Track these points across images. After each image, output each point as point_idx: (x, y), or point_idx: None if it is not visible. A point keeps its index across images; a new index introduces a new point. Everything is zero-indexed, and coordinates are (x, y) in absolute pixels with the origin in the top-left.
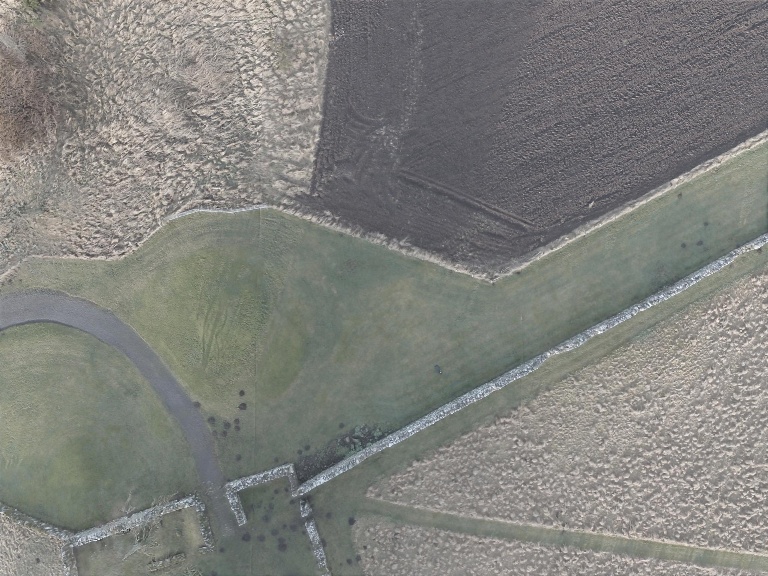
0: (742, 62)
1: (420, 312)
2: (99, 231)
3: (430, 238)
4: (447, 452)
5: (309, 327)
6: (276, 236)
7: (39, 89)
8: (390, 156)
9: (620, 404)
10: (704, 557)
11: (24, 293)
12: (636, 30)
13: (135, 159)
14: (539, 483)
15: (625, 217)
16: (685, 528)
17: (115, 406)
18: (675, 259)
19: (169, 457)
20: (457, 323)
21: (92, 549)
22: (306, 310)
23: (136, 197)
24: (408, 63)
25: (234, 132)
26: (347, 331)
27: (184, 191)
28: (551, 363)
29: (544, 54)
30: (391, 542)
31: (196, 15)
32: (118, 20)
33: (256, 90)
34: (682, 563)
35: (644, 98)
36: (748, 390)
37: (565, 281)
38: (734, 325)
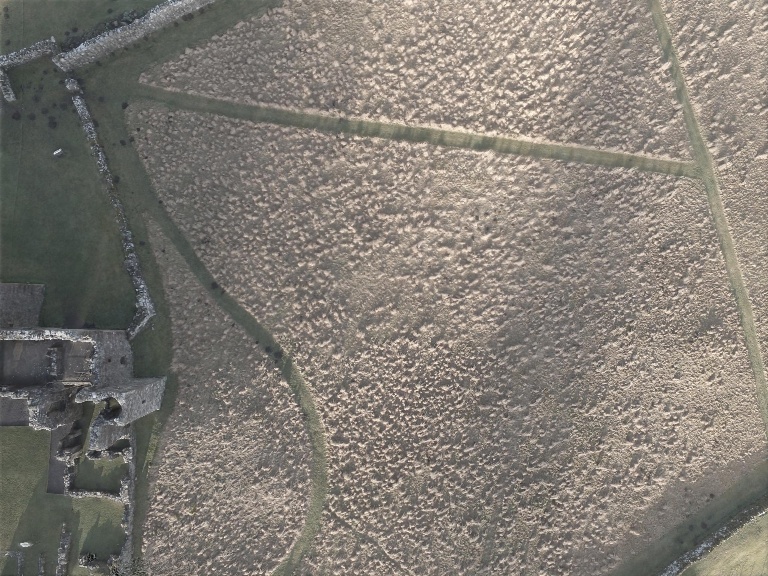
0: None
1: None
2: None
3: None
4: (220, 41)
5: None
6: None
7: None
8: None
9: None
10: (483, 144)
11: None
12: None
13: None
14: (313, 71)
15: None
16: (462, 115)
17: None
18: None
19: None
20: None
21: None
22: None
23: None
24: None
25: None
26: None
27: None
28: None
29: None
30: (165, 125)
31: None
32: None
33: None
34: (460, 149)
35: None
36: None
37: None
38: None
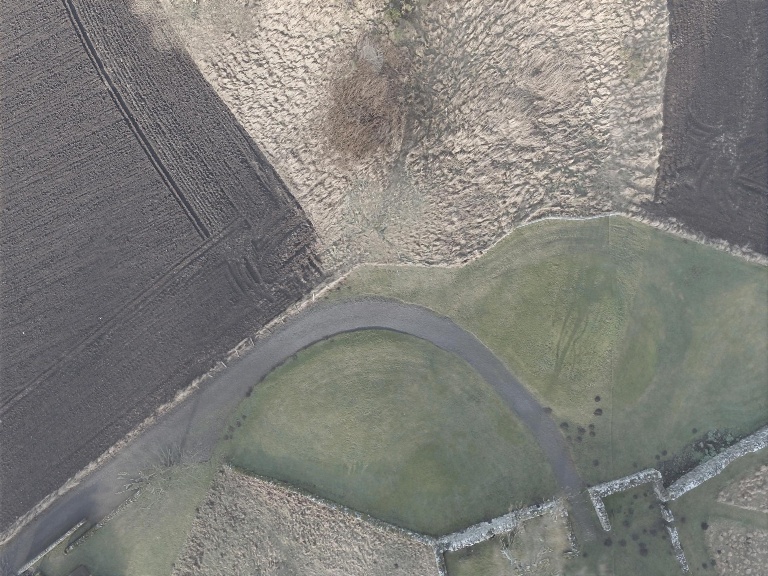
0: None
1: (763, 318)
2: (439, 239)
3: None
4: None
5: (661, 333)
6: (625, 243)
7: (392, 99)
8: (730, 163)
9: None
10: None
11: (354, 300)
12: None
13: (479, 167)
14: None
15: None
16: None
17: (459, 412)
18: None
19: (522, 463)
20: None
21: (459, 554)
22: (657, 316)
23: (480, 205)
24: (744, 71)
25: (581, 140)
26: (697, 337)
27: (532, 199)
28: None
29: None
30: (744, 547)
31: (543, 25)
32: (468, 30)
33: (603, 99)
34: None
35: None
36: None
37: None
38: None
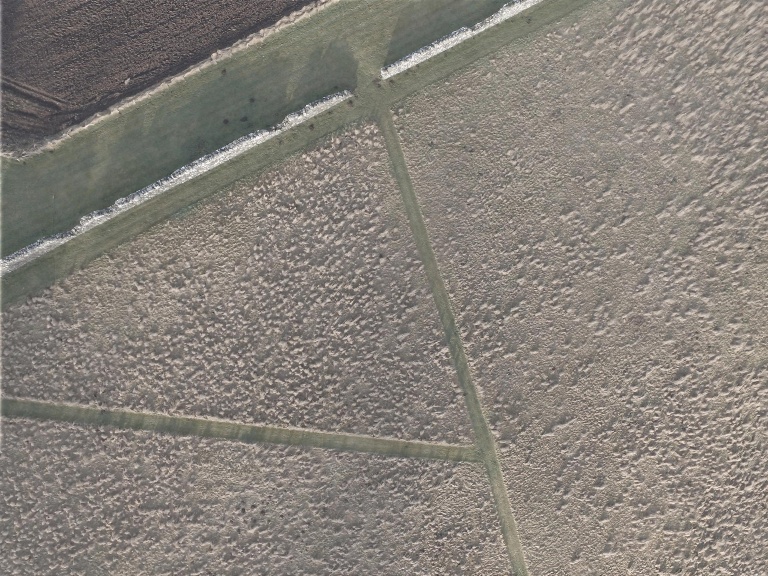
0: None
1: None
2: None
3: None
4: None
5: None
6: None
7: None
8: None
9: (159, 282)
10: (251, 434)
11: None
12: None
13: None
14: (74, 362)
15: (165, 94)
16: (229, 405)
17: None
18: (216, 135)
19: None
20: None
21: None
22: None
23: None
24: None
25: None
26: None
27: None
28: (85, 241)
29: None
30: None
31: None
32: None
33: None
34: (227, 440)
35: None
36: (297, 266)
37: (100, 159)
38: (284, 202)
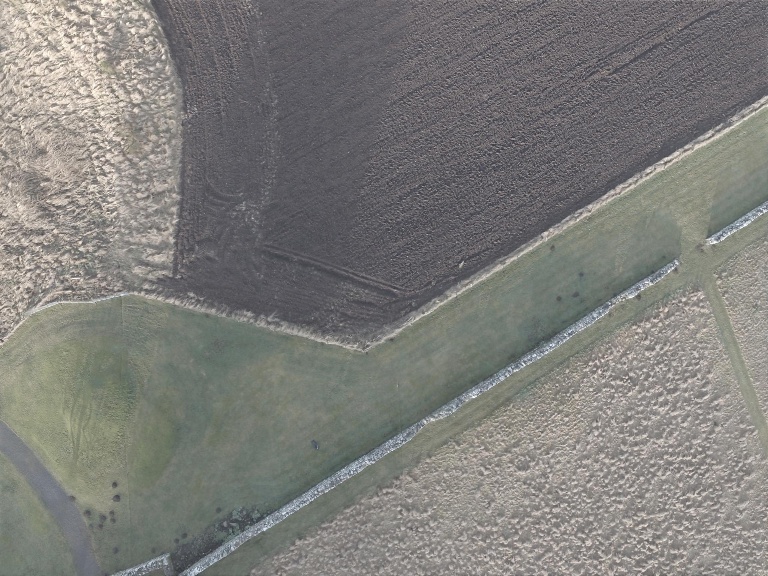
0: (606, 107)
1: (293, 387)
2: None
3: (299, 311)
4: (330, 528)
5: (179, 413)
6: (140, 322)
7: None
8: (252, 231)
9: (504, 465)
10: None
11: None
12: (495, 83)
13: None
14: (426, 552)
15: (497, 274)
16: None
17: None
18: (551, 313)
19: (47, 554)
20: (332, 396)
21: None
22: (175, 396)
23: None
24: (264, 135)
25: (90, 220)
26: (218, 414)
27: (44, 283)
28: (430, 429)
29: (403, 115)
30: None
31: (43, 104)
32: None
33: (109, 176)
34: None
35: (508, 152)
36: (635, 440)
37: (440, 344)
38: (617, 375)
